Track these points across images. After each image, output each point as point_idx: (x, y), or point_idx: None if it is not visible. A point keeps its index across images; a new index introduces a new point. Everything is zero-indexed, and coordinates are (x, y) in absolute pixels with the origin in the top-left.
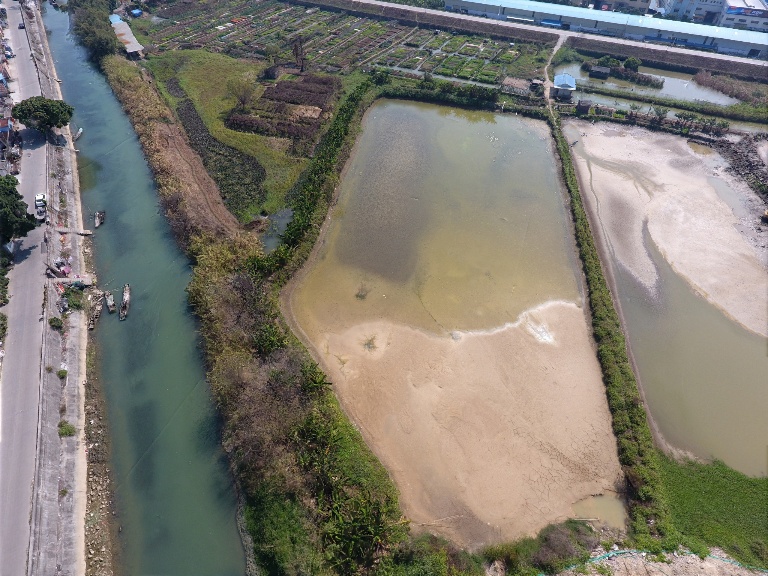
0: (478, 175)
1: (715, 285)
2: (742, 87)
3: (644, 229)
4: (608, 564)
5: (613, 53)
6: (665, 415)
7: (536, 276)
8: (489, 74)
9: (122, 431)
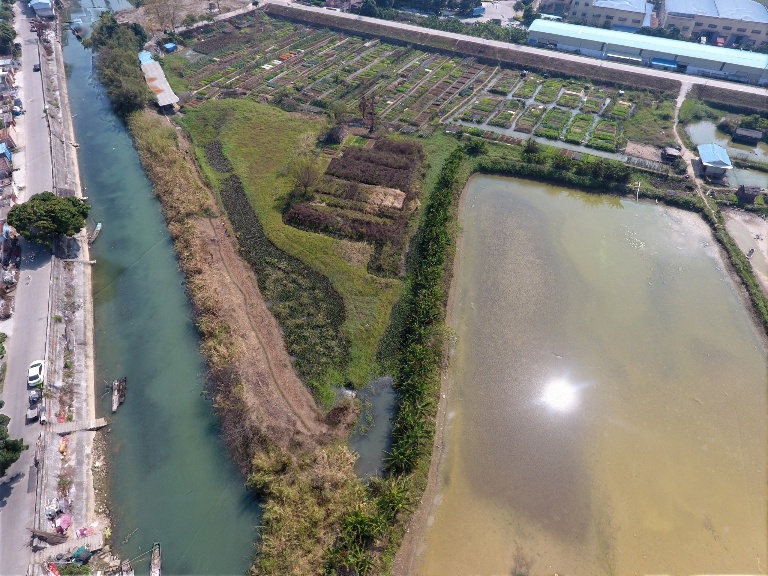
0: (635, 310)
1: None
2: None
3: None
4: None
5: (754, 107)
6: None
7: None
8: (606, 138)
9: None
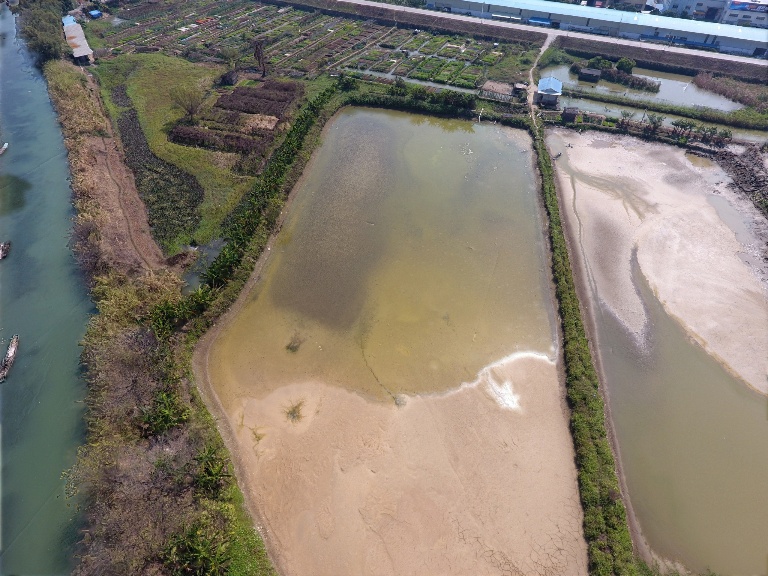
0: (446, 194)
1: (714, 330)
2: (747, 90)
3: (633, 259)
4: None
5: (605, 53)
6: (650, 509)
7: (503, 320)
8: (468, 78)
9: None
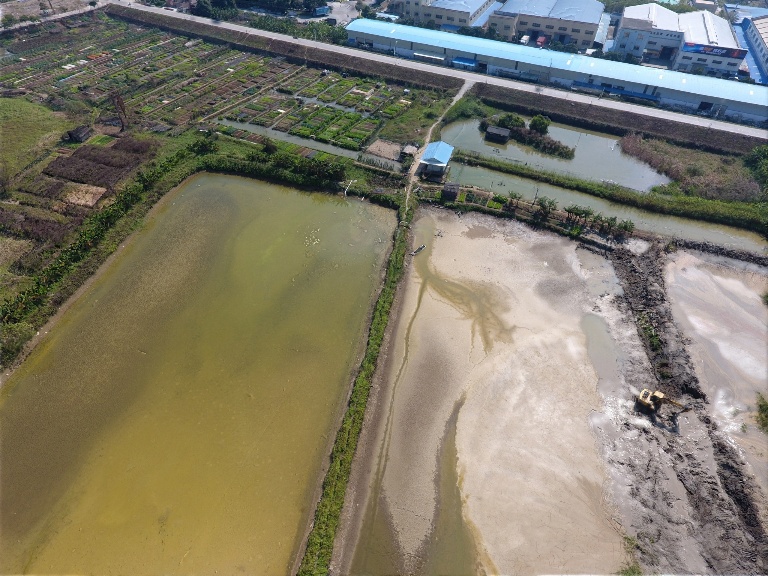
0: (258, 307)
1: (517, 553)
2: (676, 159)
3: (451, 420)
4: None
5: (526, 105)
6: None
7: (236, 526)
8: (355, 136)
9: None
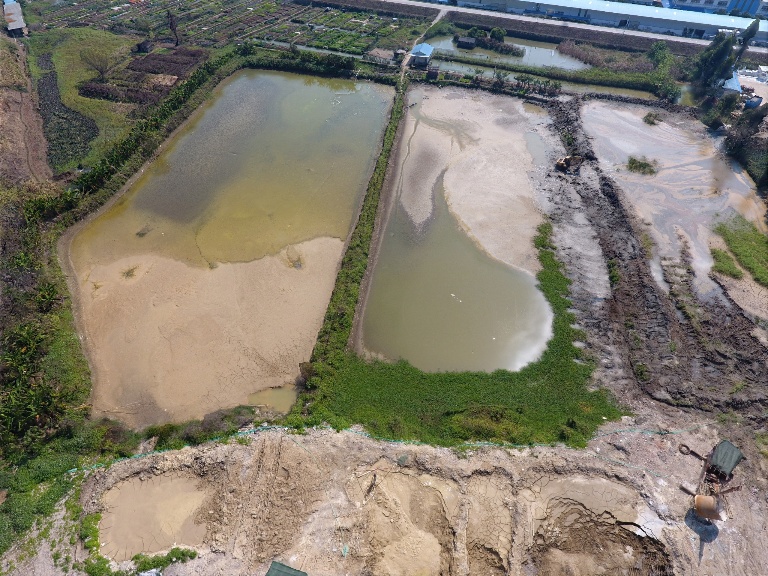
0: (305, 133)
1: (481, 222)
2: (597, 54)
3: (440, 176)
4: (251, 437)
5: (488, 25)
6: (375, 326)
7: (315, 216)
8: (358, 46)
9: None
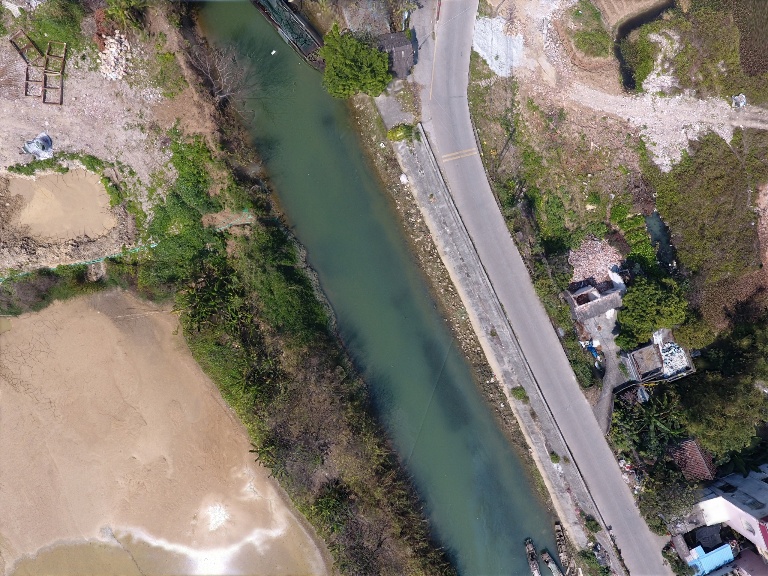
0: None
1: None
2: None
3: None
4: None
5: None
6: None
7: None
8: None
9: (471, 397)
